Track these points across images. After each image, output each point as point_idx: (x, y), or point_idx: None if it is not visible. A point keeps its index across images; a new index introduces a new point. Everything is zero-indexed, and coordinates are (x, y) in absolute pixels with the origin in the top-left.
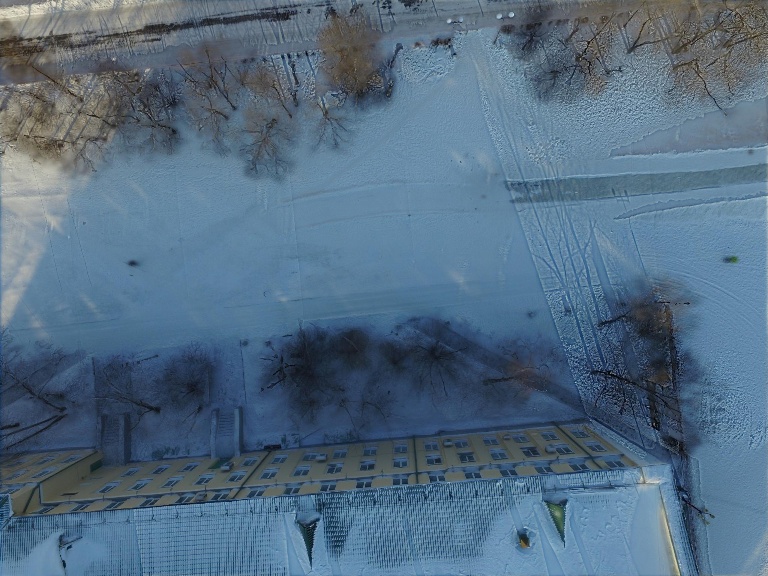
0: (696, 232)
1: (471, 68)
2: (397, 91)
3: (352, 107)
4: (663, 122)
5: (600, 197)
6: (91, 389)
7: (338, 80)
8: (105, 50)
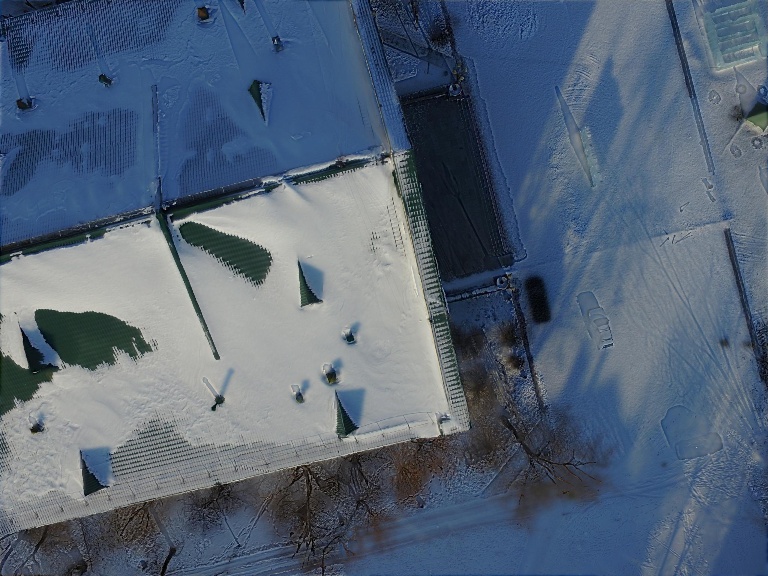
0: None
1: None
2: None
3: None
4: None
5: None
6: None
7: None
8: None
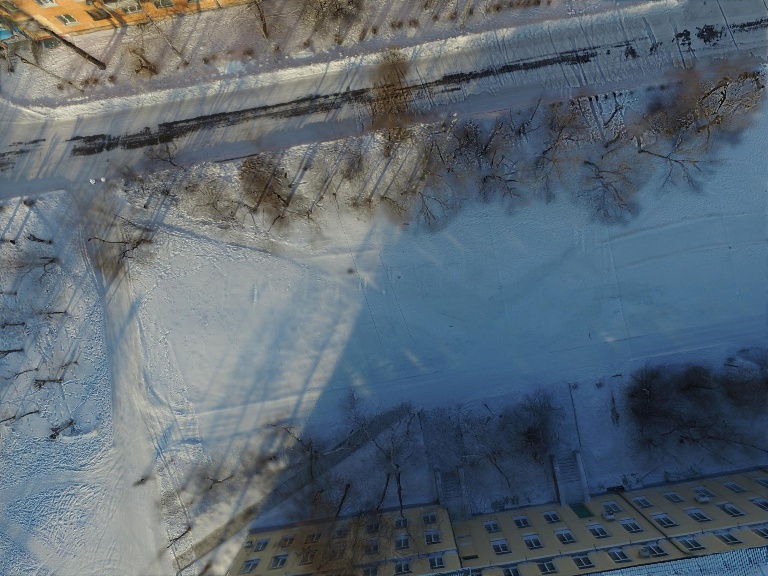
0: None
1: None
2: None
3: (663, 144)
4: None
5: None
6: (421, 444)
7: (650, 119)
8: (405, 103)
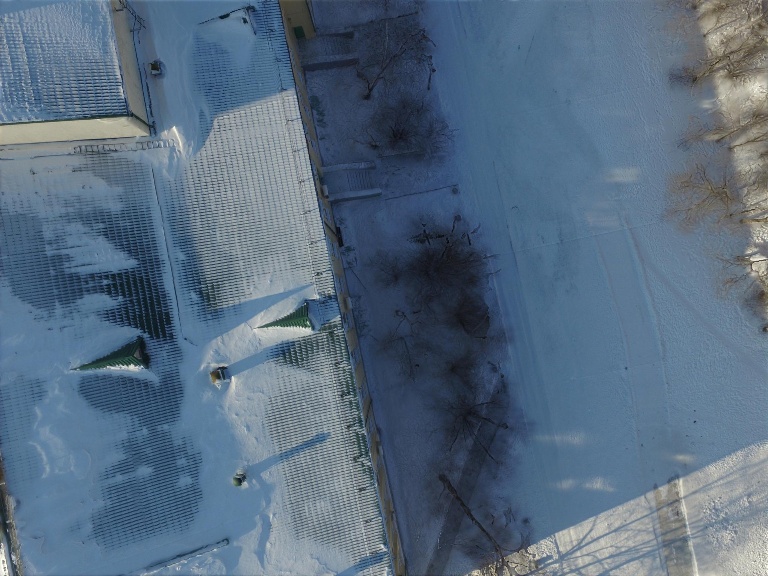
0: None
1: None
2: None
3: None
4: None
5: None
6: (381, 15)
7: None
8: None
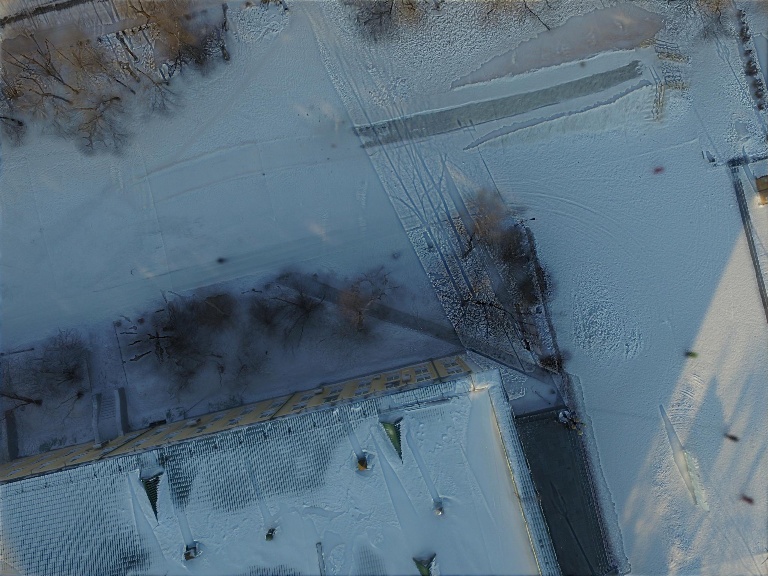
0: (545, 151)
1: (306, 21)
2: (236, 53)
3: (193, 75)
4: (498, 48)
5: (447, 130)
6: None
7: (175, 50)
8: None
